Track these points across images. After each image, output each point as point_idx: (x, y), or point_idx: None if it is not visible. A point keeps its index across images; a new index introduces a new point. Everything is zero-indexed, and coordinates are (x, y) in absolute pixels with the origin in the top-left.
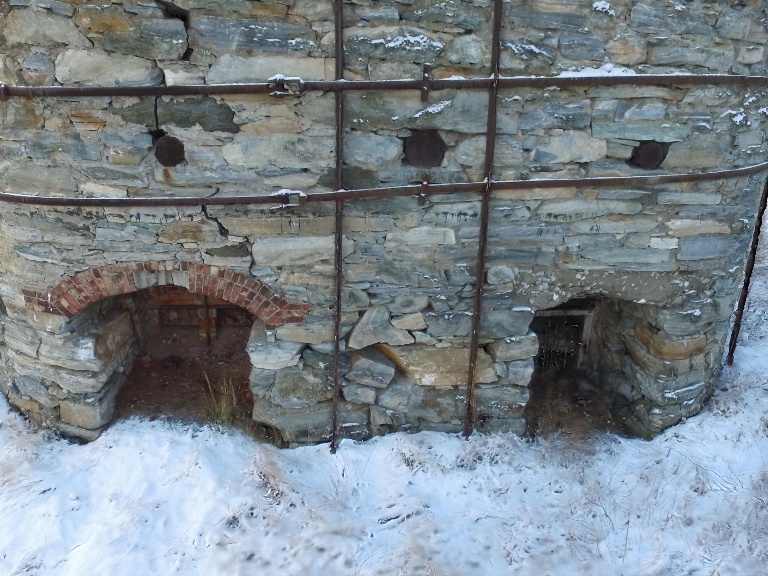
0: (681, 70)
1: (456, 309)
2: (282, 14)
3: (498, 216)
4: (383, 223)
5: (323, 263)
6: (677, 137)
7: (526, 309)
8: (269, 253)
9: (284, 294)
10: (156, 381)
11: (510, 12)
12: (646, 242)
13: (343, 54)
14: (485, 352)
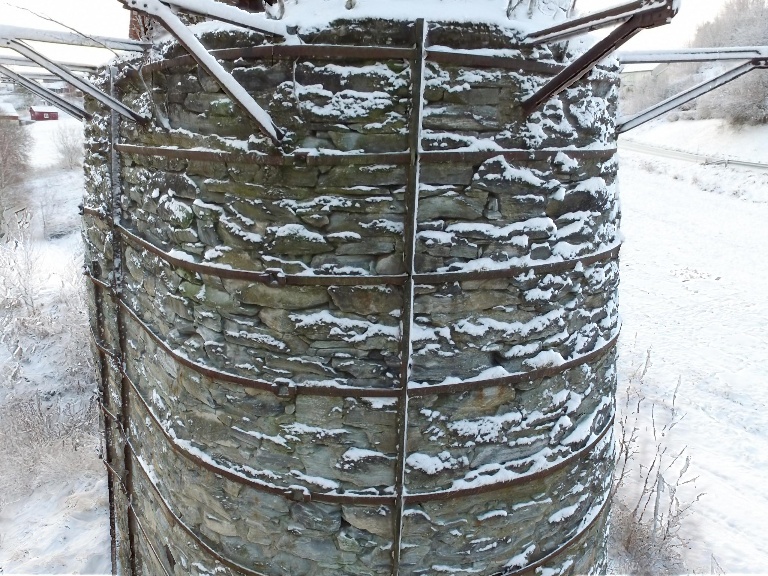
0: None
1: None
2: None
3: None
4: None
5: None
6: None
7: None
8: None
9: None
10: None
11: None
12: None
13: (108, 390)
14: None
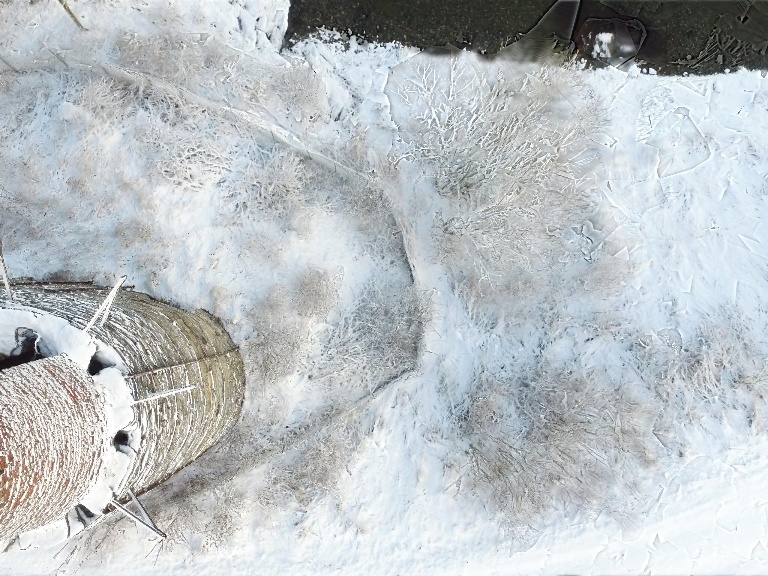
0: None
1: None
2: None
3: None
4: None
5: None
6: None
7: None
8: None
9: None
10: None
11: None
12: None
13: None
14: None
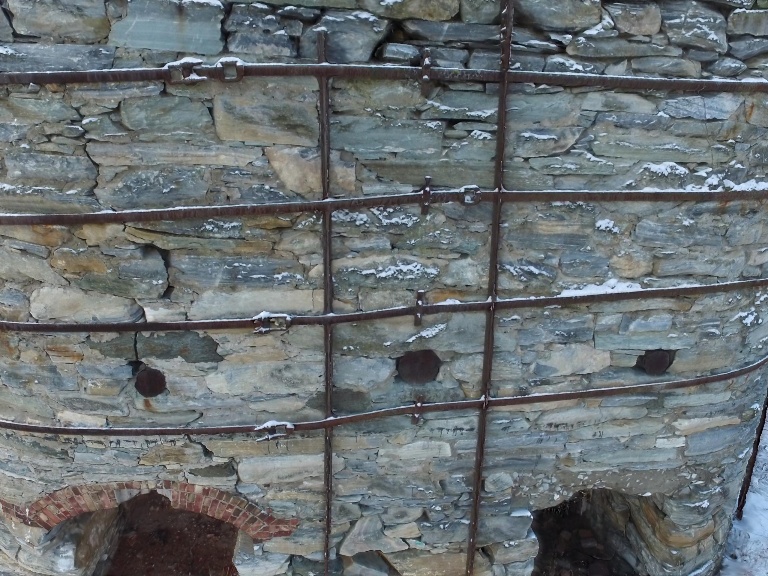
0: (689, 282)
1: (452, 517)
2: (267, 250)
3: (496, 429)
4: (375, 441)
5: (312, 478)
6: (684, 345)
7: (525, 514)
8: (256, 472)
9: (271, 510)
10: (142, 564)
11: (508, 236)
12: (652, 443)
13: (332, 286)
14: (483, 553)
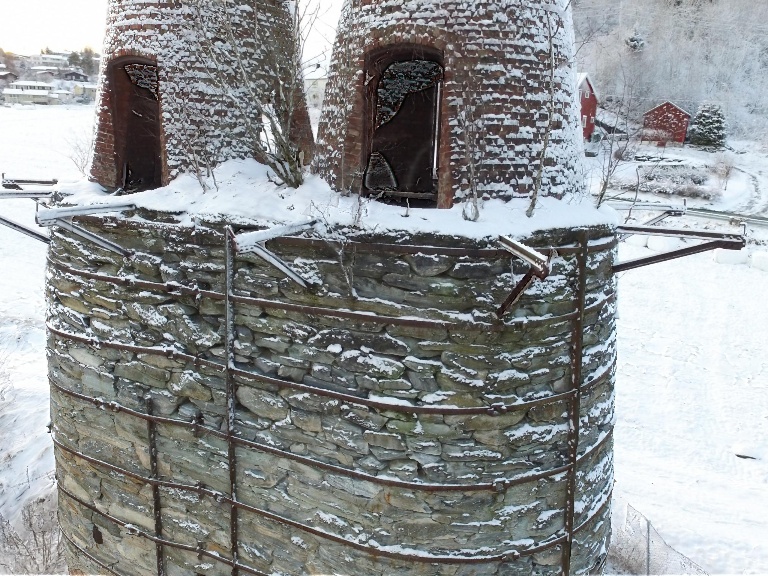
0: None
1: None
2: (136, 492)
3: None
4: None
5: None
6: None
7: None
8: None
9: None
10: None
11: (243, 527)
12: None
13: (161, 521)
14: None
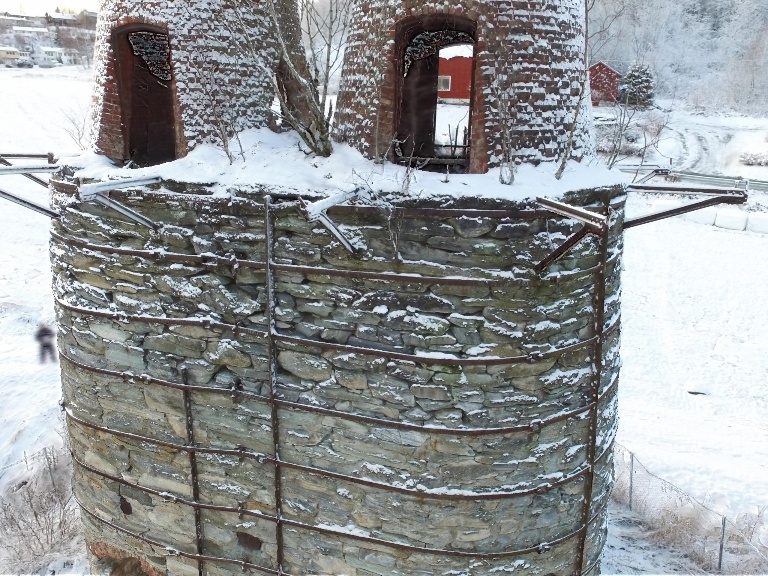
0: (402, 541)
1: None
2: (169, 461)
3: None
4: (227, 573)
5: None
6: None
7: None
8: (174, 568)
9: None
10: None
11: (286, 484)
12: None
13: (198, 487)
14: None
